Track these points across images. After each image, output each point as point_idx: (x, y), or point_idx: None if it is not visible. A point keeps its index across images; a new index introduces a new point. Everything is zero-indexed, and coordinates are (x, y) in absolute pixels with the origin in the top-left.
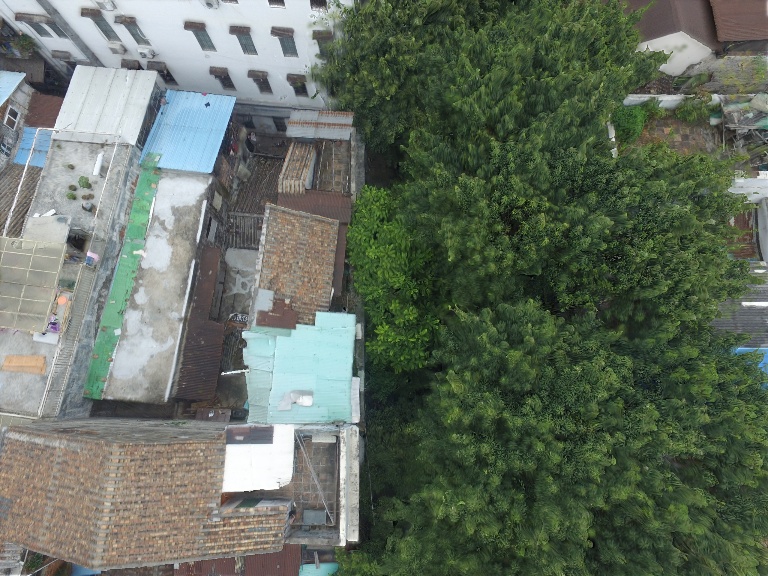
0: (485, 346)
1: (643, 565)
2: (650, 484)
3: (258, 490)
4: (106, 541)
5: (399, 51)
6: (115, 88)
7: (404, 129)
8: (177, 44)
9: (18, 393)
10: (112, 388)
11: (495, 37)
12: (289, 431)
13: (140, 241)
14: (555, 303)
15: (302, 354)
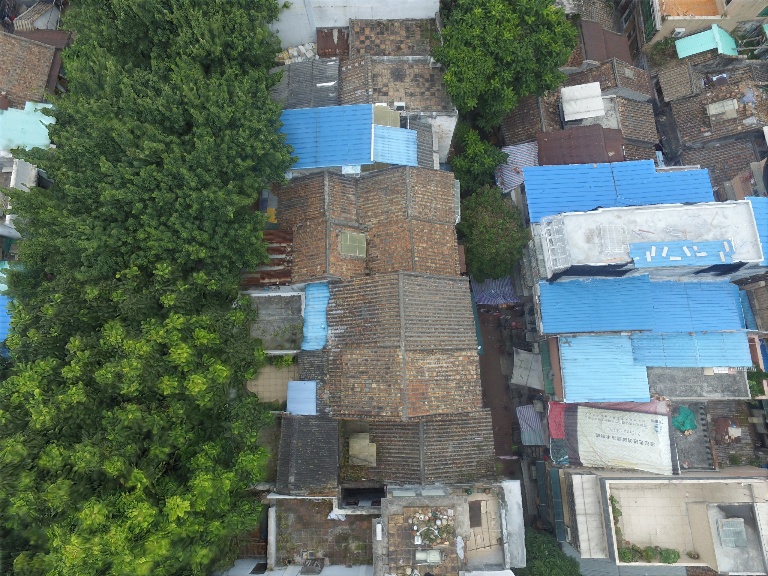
0: None
1: None
2: None
3: None
4: None
5: None
6: None
7: None
8: None
9: None
10: None
11: None
12: None
13: None
14: None
15: (12, 128)
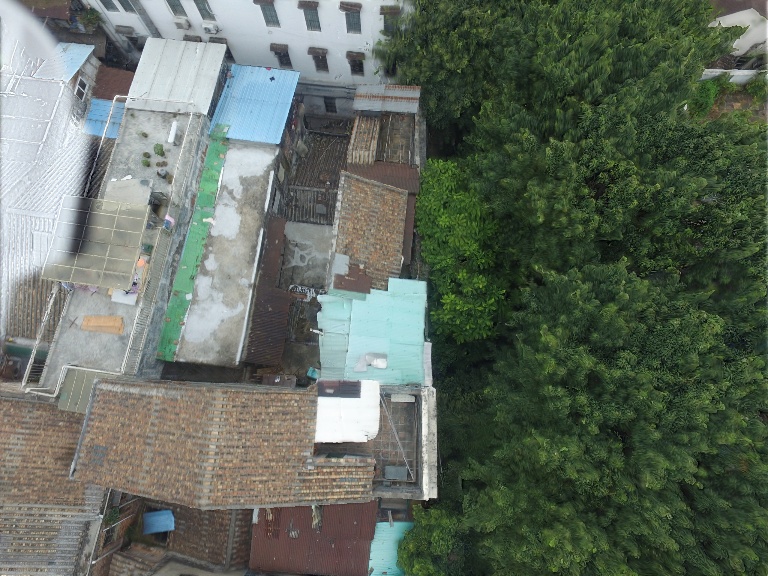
0: (577, 303)
1: (747, 510)
2: (752, 433)
3: (341, 446)
4: (212, 482)
5: (472, 24)
6: (186, 60)
7: (470, 103)
8: (242, 19)
9: (97, 352)
10: (184, 351)
11: (573, 9)
12: (375, 387)
13: (210, 209)
14: (635, 268)
15: (376, 318)
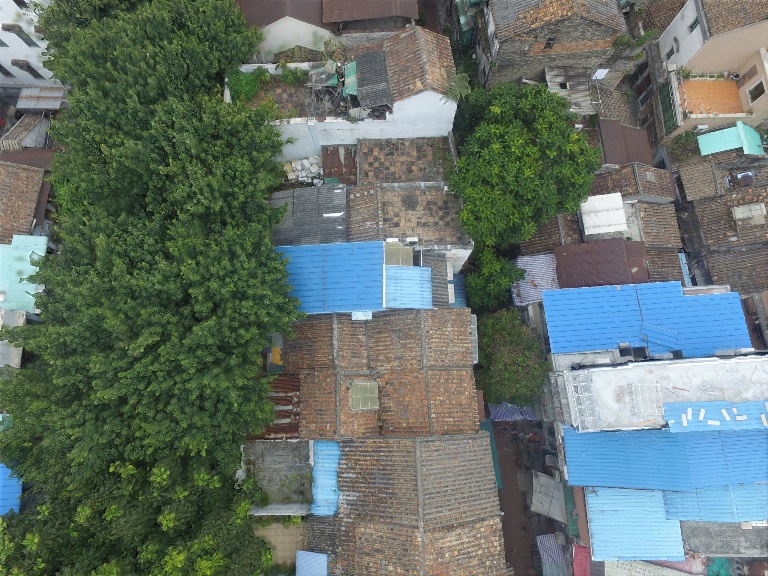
0: (60, 235)
1: None
2: None
3: None
4: None
5: None
6: None
7: None
8: None
9: None
10: None
11: None
12: None
13: None
14: None
15: None
